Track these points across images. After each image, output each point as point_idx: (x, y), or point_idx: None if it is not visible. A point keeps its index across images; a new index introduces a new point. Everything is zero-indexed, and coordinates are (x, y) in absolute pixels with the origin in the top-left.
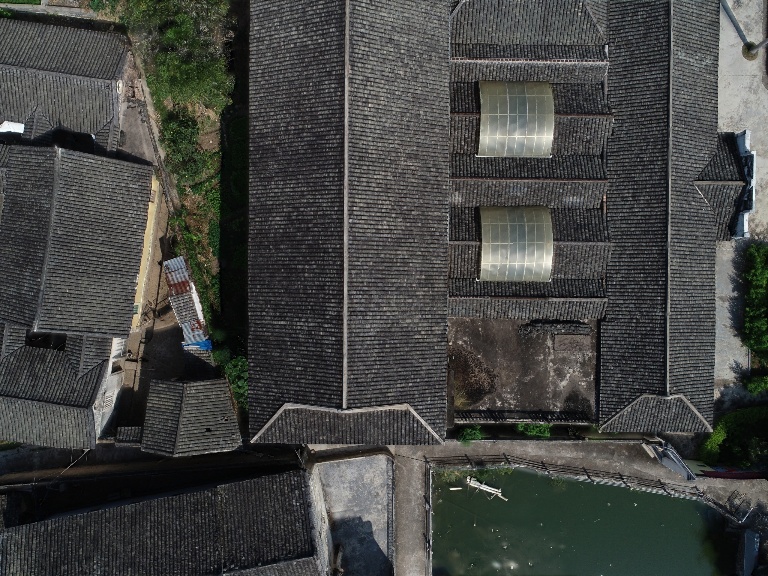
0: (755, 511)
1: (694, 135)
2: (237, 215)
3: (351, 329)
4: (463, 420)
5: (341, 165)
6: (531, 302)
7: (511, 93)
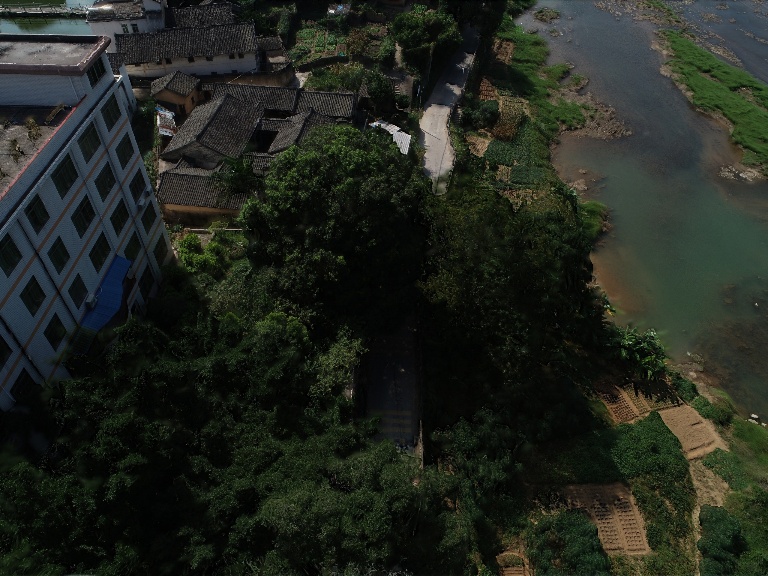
0: None
1: None
2: None
3: None
4: None
5: None
6: None
7: None
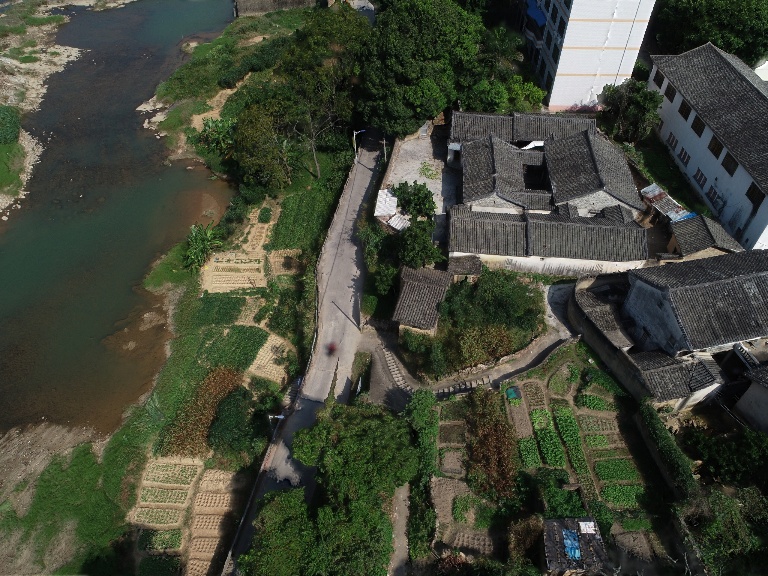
0: None
1: None
2: (663, 184)
3: None
4: None
5: (763, 97)
6: None
7: None
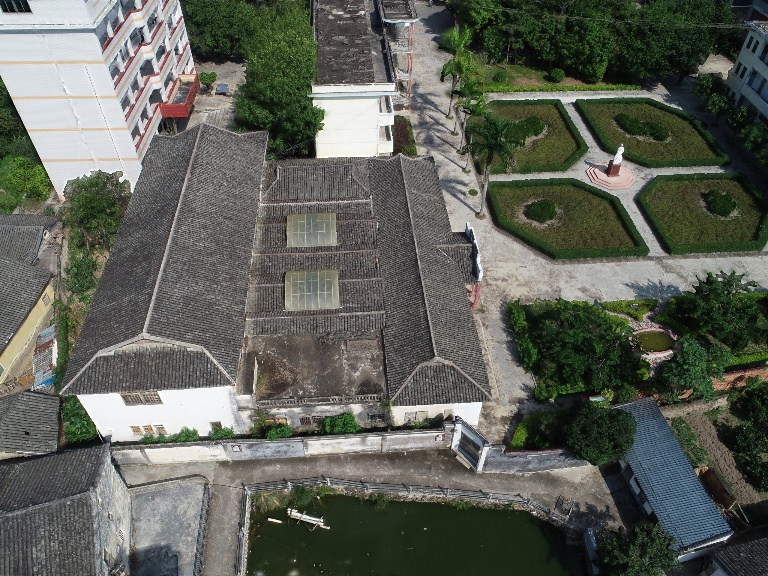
0: (587, 515)
1: (432, 225)
2: None
3: (162, 288)
4: (268, 407)
5: (175, 211)
6: (325, 318)
7: (308, 214)
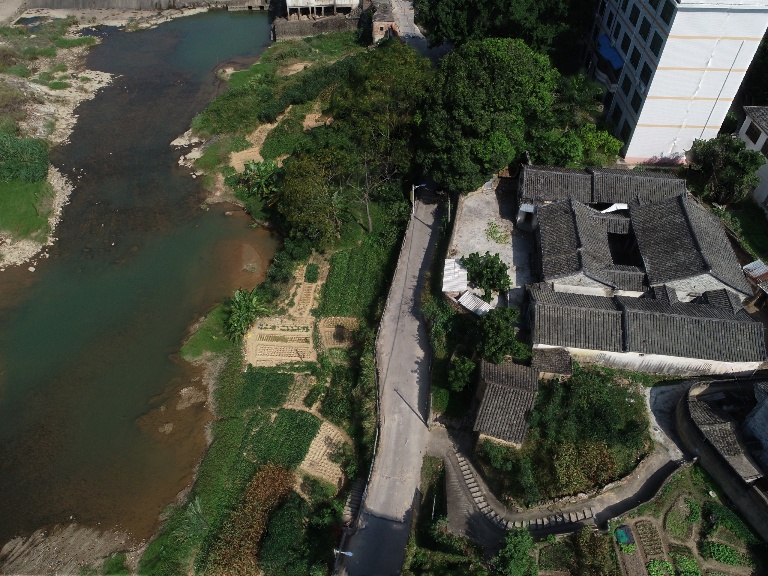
0: None
1: None
2: (764, 256)
3: None
4: None
5: None
6: None
7: None
